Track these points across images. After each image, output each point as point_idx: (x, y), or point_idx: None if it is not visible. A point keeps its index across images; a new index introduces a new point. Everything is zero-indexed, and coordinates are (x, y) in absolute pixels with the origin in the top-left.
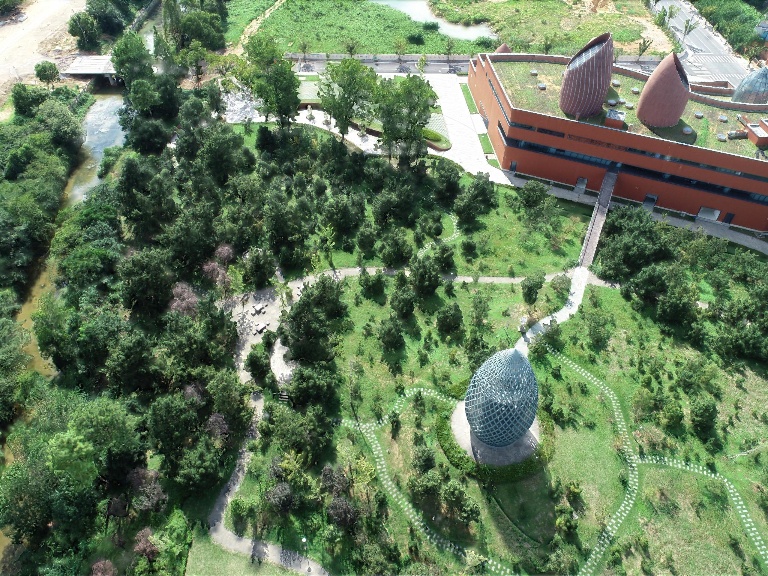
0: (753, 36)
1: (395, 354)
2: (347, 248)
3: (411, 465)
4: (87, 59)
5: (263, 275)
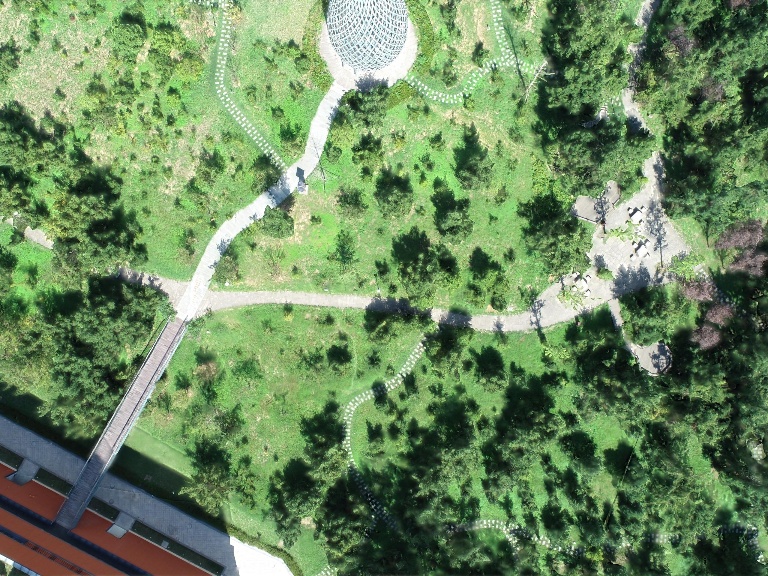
0: None
1: (470, 157)
2: None
3: None
4: None
5: (643, 302)
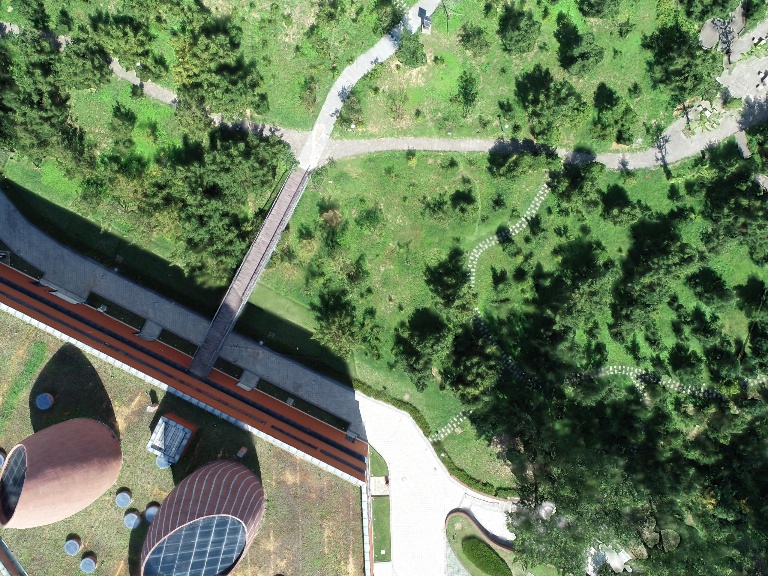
0: None
1: None
2: None
3: None
4: None
5: None
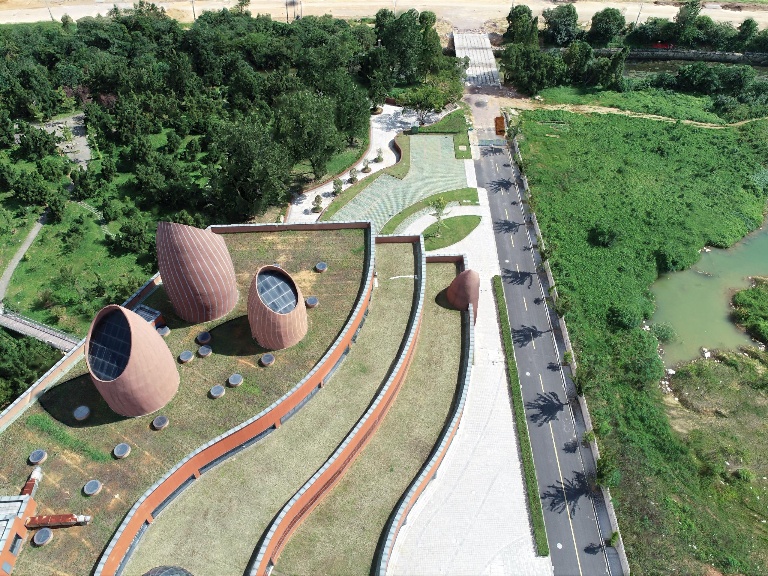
0: None
1: None
2: None
3: None
4: (480, 38)
5: None
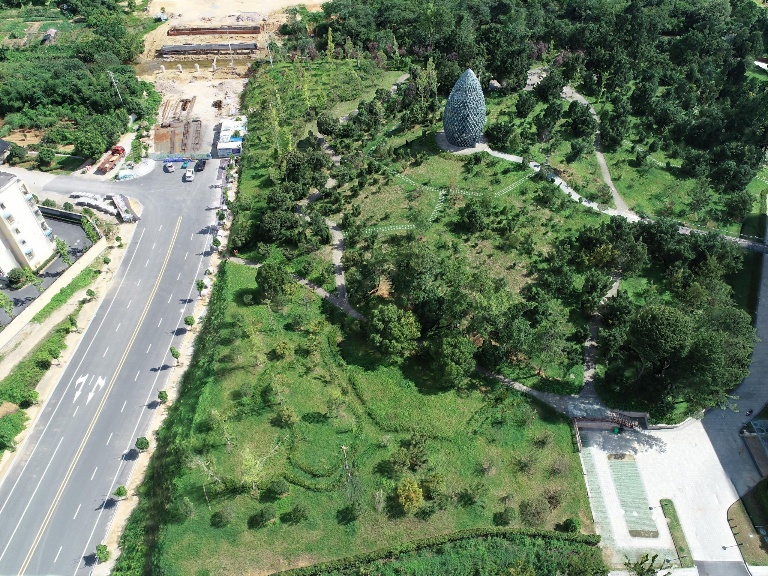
0: None
1: None
2: None
3: None
4: None
5: (569, 72)
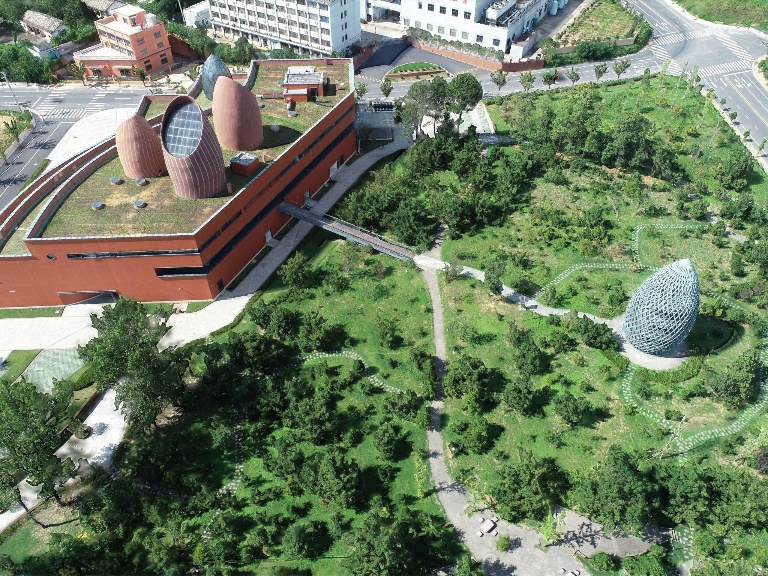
0: (49, 62)
1: None
2: (390, 475)
3: (728, 397)
4: None
5: None
